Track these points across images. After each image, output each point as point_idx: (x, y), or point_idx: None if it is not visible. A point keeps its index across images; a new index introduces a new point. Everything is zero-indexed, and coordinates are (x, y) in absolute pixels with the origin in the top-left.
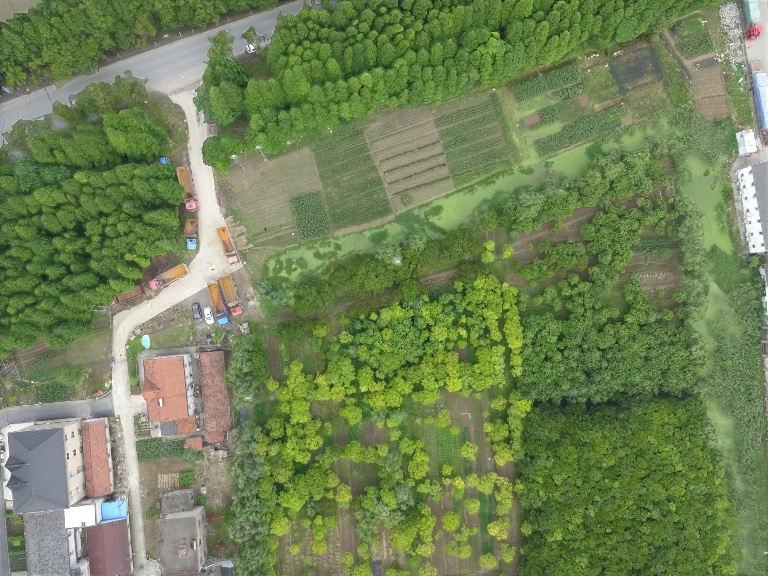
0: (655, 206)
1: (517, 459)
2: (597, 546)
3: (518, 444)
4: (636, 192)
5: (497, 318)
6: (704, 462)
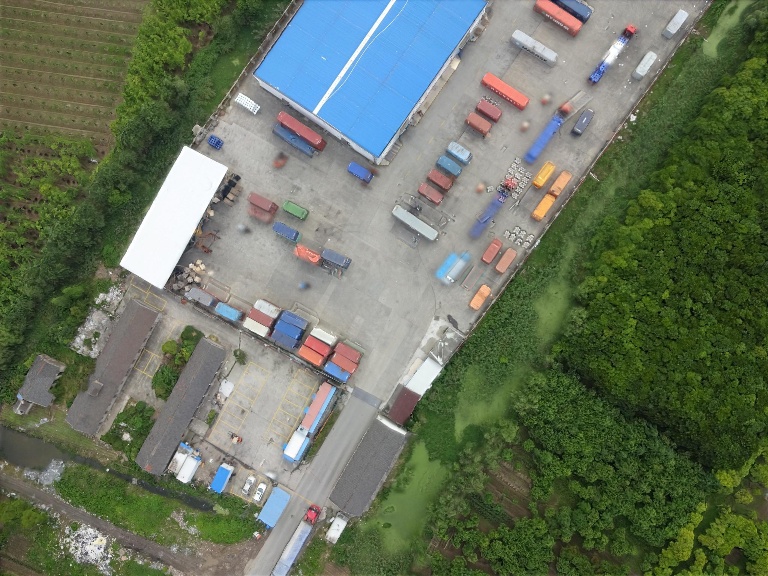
0: (463, 544)
1: (766, 438)
2: (762, 318)
3: (759, 453)
4: (473, 573)
5: (689, 572)
6: (606, 308)
